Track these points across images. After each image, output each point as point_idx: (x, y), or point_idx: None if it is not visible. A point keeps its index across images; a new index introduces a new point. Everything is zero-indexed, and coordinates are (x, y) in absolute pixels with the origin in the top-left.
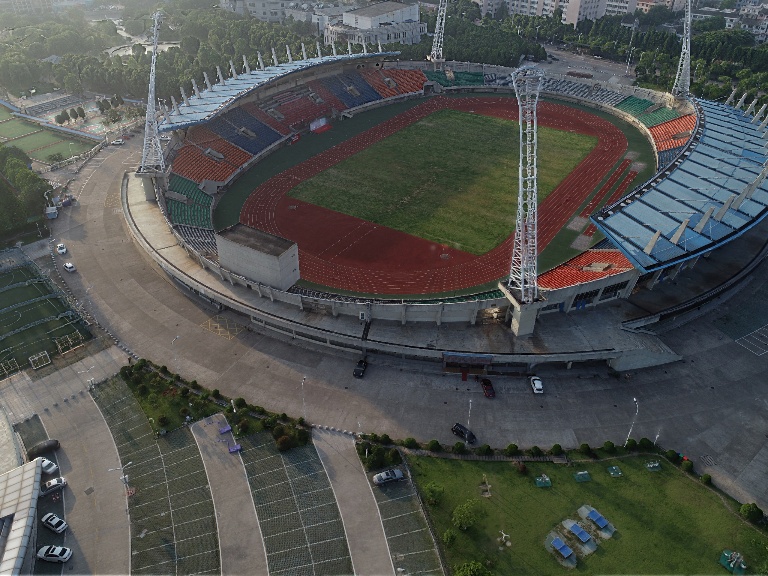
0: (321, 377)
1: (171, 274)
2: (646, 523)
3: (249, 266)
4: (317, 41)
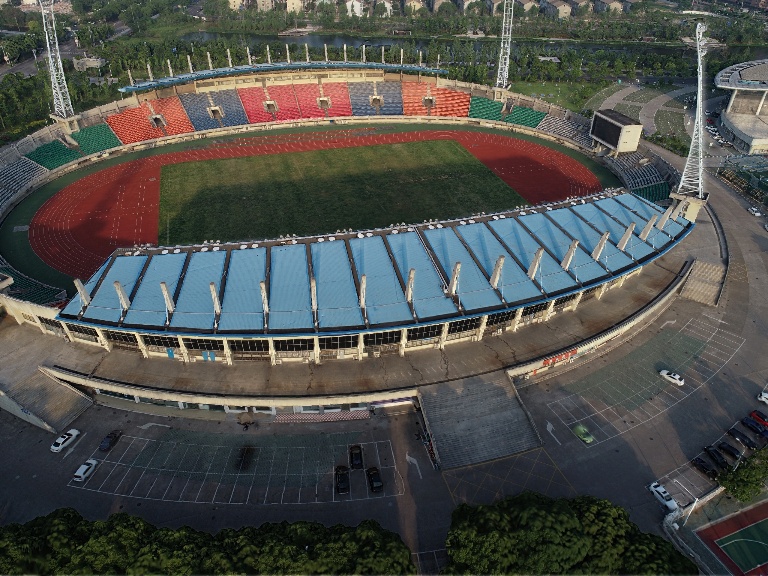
0: None
1: None
2: (521, 92)
3: None
4: (263, 281)
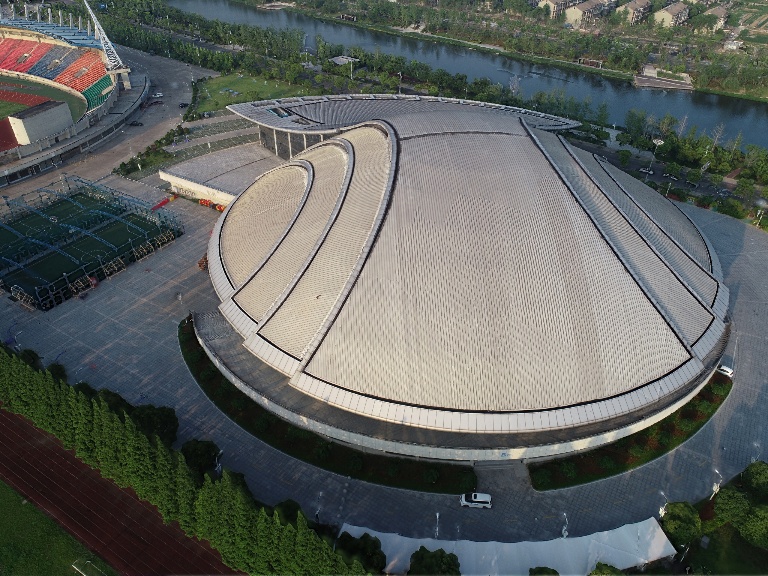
0: (140, 132)
1: (3, 185)
2: None
3: (53, 124)
4: None
